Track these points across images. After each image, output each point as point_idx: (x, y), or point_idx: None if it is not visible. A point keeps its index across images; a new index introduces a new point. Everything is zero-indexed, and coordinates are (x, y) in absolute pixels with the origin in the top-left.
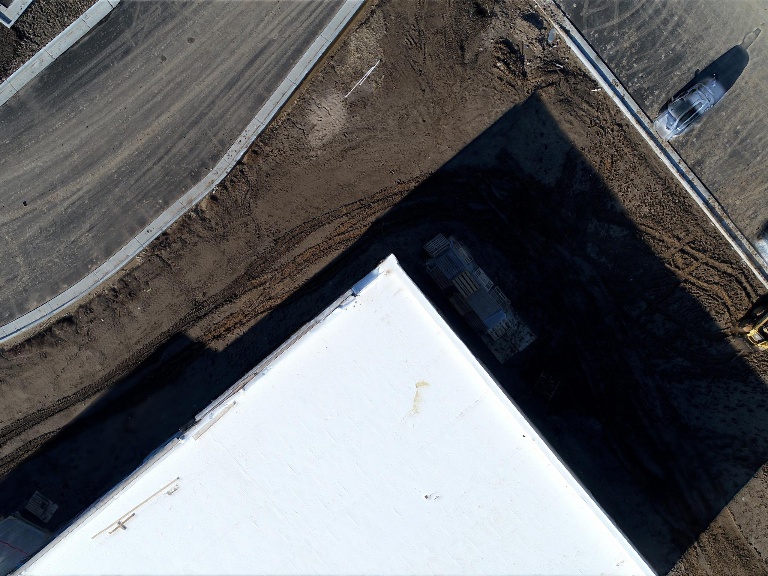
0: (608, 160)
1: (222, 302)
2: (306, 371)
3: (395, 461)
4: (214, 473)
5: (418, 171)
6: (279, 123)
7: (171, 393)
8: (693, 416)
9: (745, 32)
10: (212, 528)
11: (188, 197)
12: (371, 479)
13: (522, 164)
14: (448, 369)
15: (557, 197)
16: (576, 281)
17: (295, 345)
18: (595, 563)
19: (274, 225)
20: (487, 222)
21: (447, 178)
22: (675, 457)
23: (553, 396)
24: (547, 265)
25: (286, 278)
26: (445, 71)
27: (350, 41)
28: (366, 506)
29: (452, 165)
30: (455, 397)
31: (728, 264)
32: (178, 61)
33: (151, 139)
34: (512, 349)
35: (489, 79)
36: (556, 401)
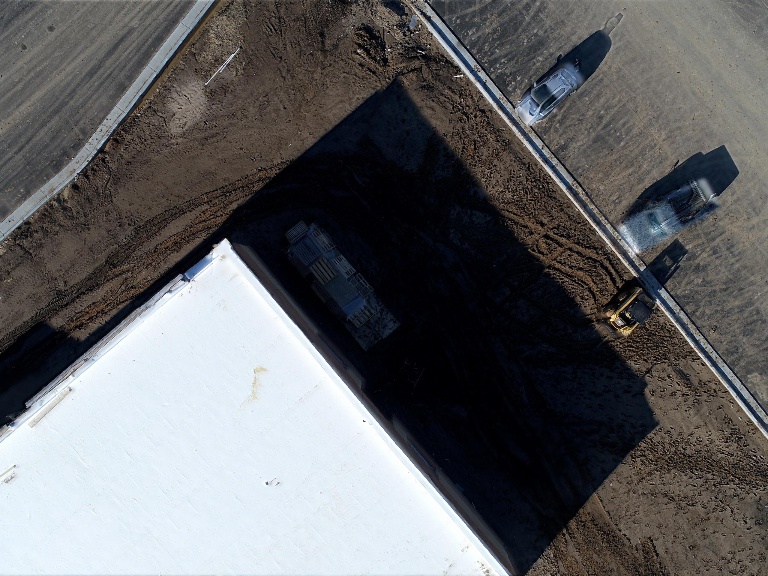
0: (471, 146)
1: (84, 291)
2: (142, 357)
3: (234, 447)
4: (51, 461)
5: (279, 158)
6: (141, 111)
7: (33, 383)
8: (559, 402)
9: (607, 17)
10: (50, 516)
11: (50, 186)
12: (211, 466)
13: (384, 151)
14: (286, 354)
15: (419, 183)
16: (439, 267)
17: (125, 331)
18: (439, 549)
19: (135, 213)
20: (349, 209)
21: (308, 165)
22: (542, 444)
23: (418, 383)
24: (410, 252)
25: (148, 267)
26: (306, 58)
27: (210, 28)
28: (206, 493)
29: (313, 152)
30: (294, 382)
31: (593, 249)
32: (38, 50)
33: (12, 128)
34: (376, 336)
35: (350, 66)
36: (421, 388)
